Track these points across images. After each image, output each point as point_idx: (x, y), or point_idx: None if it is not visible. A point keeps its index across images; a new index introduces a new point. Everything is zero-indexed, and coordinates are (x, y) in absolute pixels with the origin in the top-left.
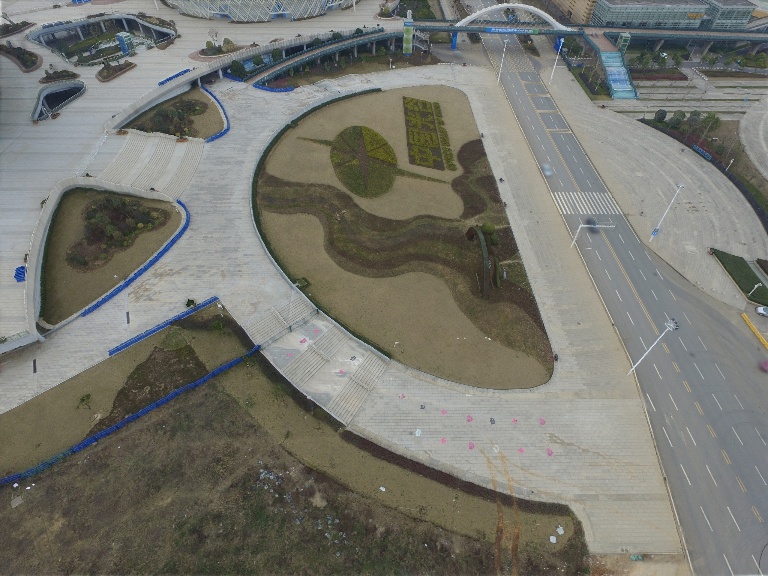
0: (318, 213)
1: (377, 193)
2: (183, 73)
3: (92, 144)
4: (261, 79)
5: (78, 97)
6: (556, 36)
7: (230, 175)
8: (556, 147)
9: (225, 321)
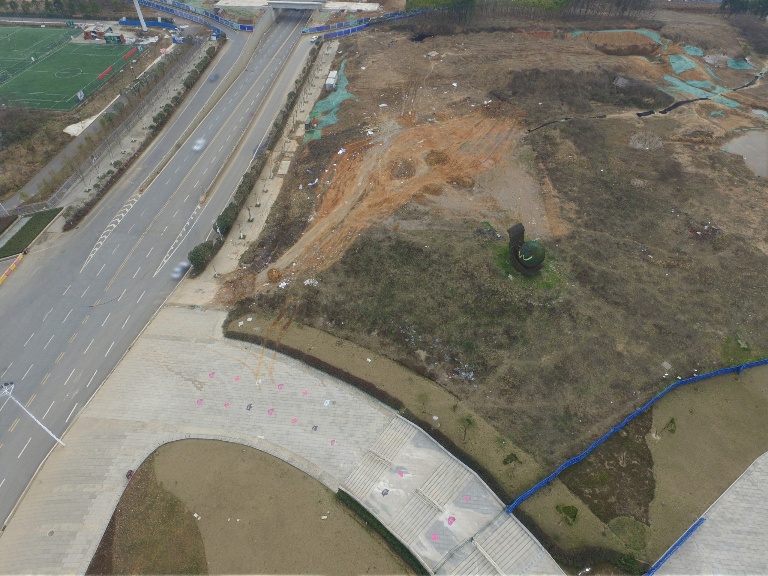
0: None
1: None
2: None
3: None
4: None
5: None
6: None
7: None
8: None
9: (571, 558)
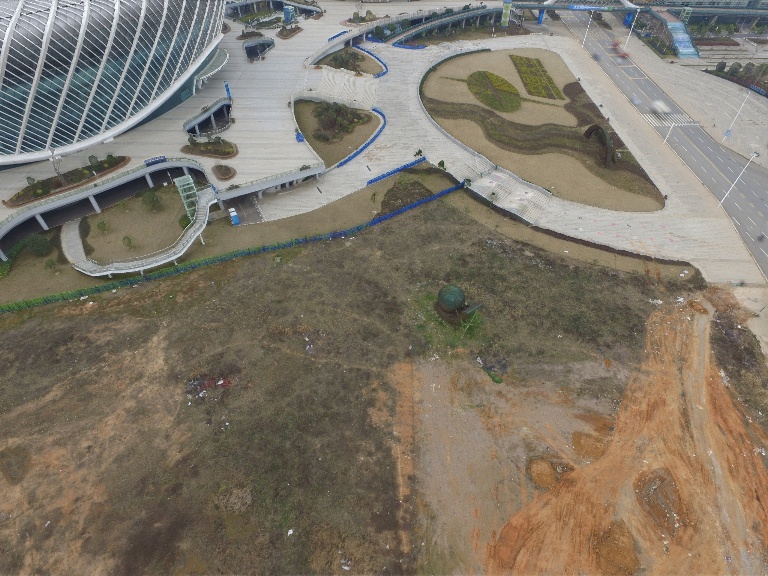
0: (474, 119)
1: (511, 110)
2: (343, 33)
3: (300, 74)
4: (398, 40)
5: (272, 48)
6: (624, 15)
7: (402, 96)
8: (639, 87)
9: (437, 169)
